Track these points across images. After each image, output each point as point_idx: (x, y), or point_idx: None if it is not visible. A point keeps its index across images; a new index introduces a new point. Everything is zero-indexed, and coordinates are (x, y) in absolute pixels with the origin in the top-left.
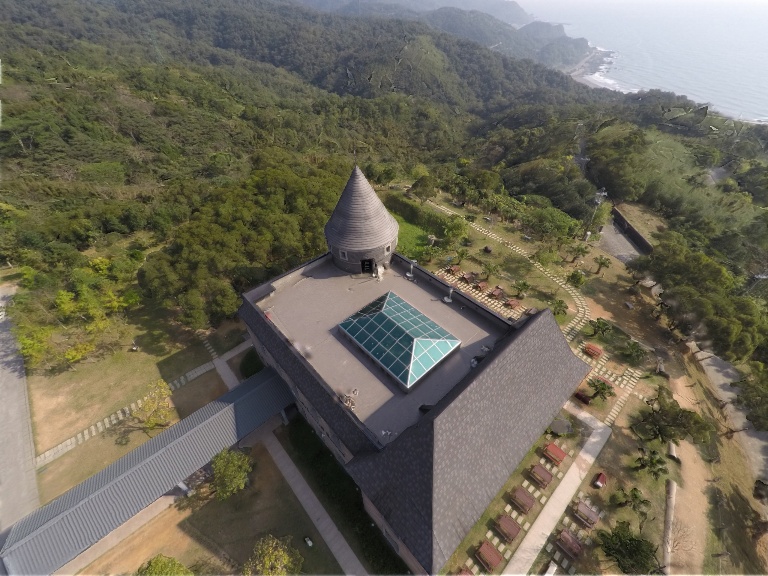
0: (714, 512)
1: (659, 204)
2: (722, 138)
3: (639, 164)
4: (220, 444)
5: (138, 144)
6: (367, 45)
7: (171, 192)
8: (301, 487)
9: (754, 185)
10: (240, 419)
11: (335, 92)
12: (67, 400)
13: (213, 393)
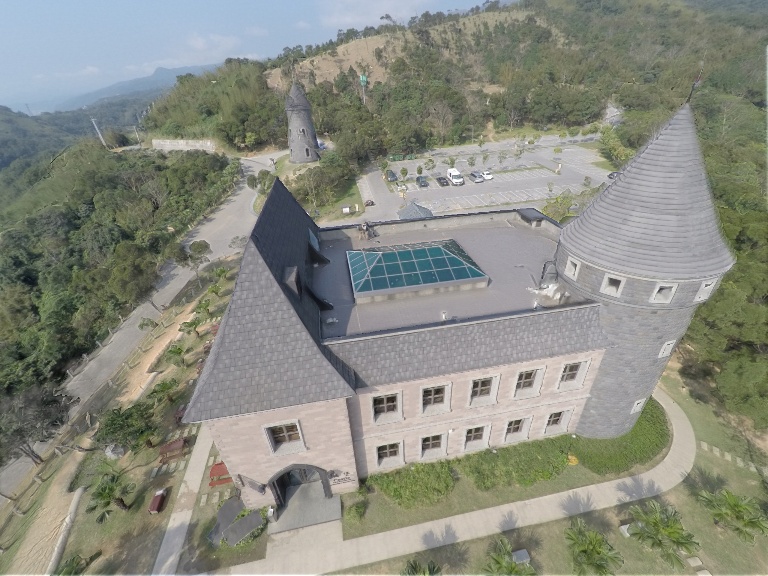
0: None
1: None
2: None
3: None
4: None
5: None
6: None
7: None
8: None
9: None
10: None
11: None
12: None
13: None
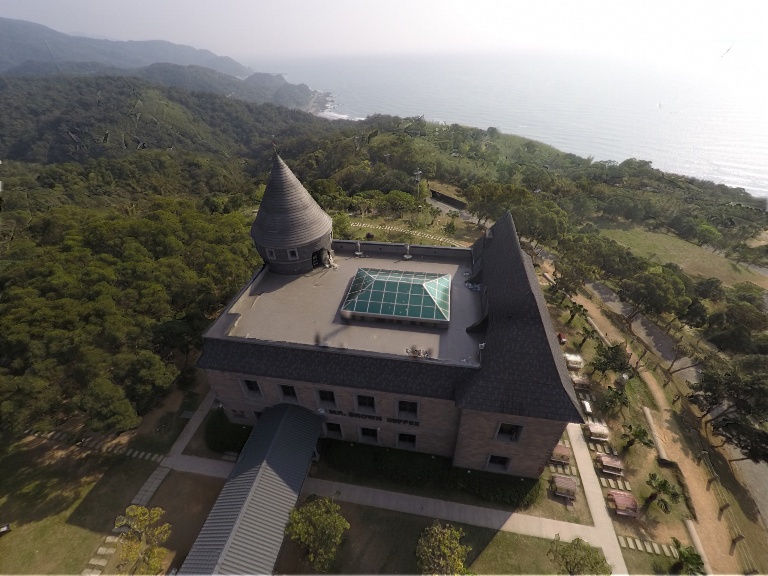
0: (614, 322)
1: (447, 175)
2: (444, 132)
3: (420, 152)
4: (282, 512)
5: None
6: (85, 104)
7: None
8: (383, 498)
9: (483, 153)
10: (284, 472)
11: (60, 161)
12: None
13: (195, 494)
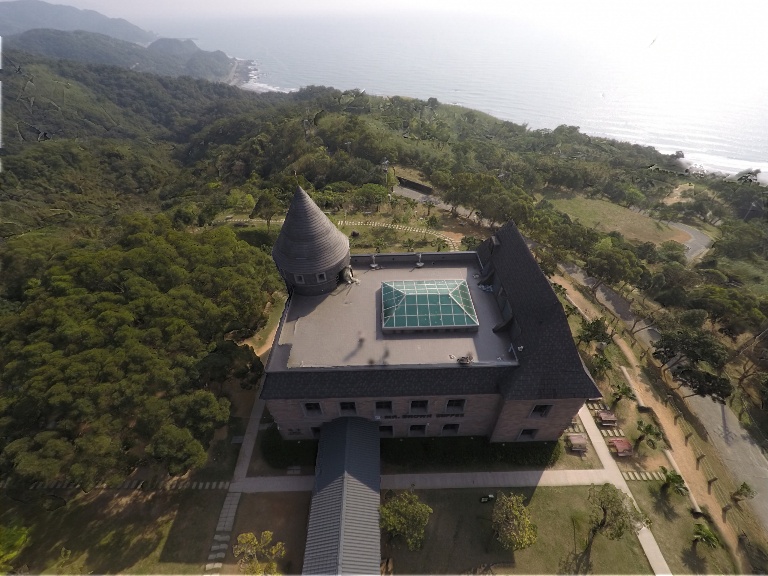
0: (585, 295)
1: (408, 159)
2: (390, 109)
3: (378, 137)
4: (372, 511)
5: None
6: None
7: None
8: (439, 480)
9: (434, 132)
10: (363, 478)
11: None
12: None
13: (274, 511)
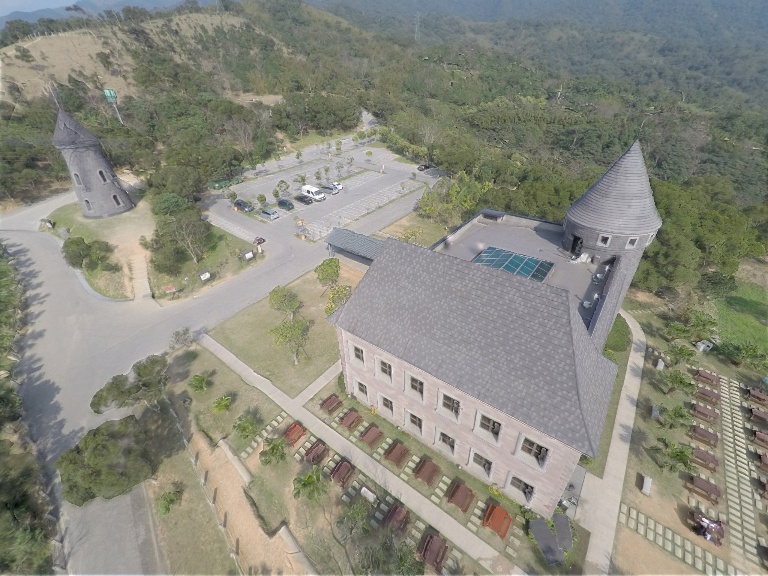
0: None
1: None
2: None
3: None
4: None
5: (654, 168)
6: None
7: (582, 177)
8: None
9: None
10: None
11: None
12: (407, 226)
13: None
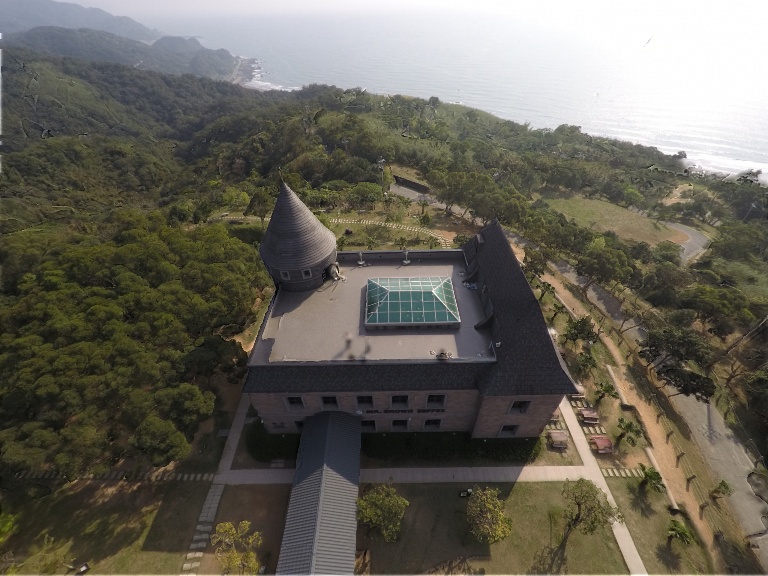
0: (575, 294)
1: (406, 158)
2: (391, 107)
3: (376, 135)
4: (350, 503)
5: None
6: None
7: None
8: (420, 474)
9: (433, 131)
10: (342, 470)
11: None
12: None
13: (256, 502)
